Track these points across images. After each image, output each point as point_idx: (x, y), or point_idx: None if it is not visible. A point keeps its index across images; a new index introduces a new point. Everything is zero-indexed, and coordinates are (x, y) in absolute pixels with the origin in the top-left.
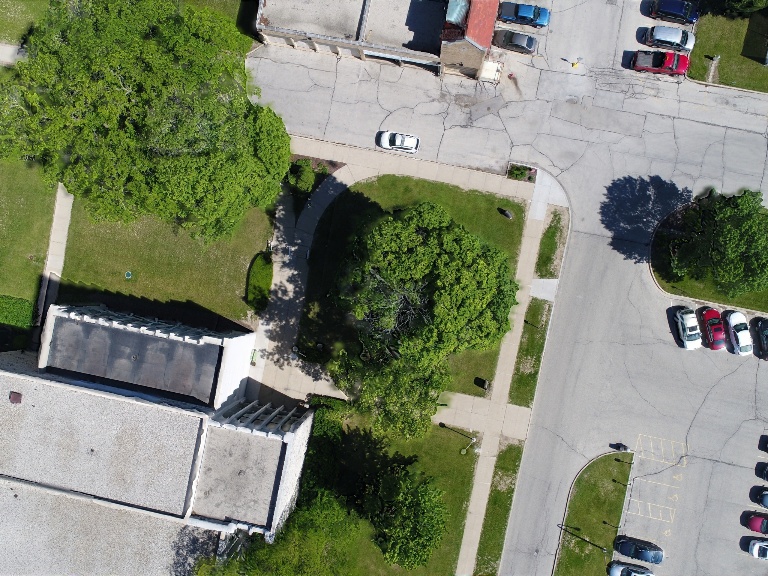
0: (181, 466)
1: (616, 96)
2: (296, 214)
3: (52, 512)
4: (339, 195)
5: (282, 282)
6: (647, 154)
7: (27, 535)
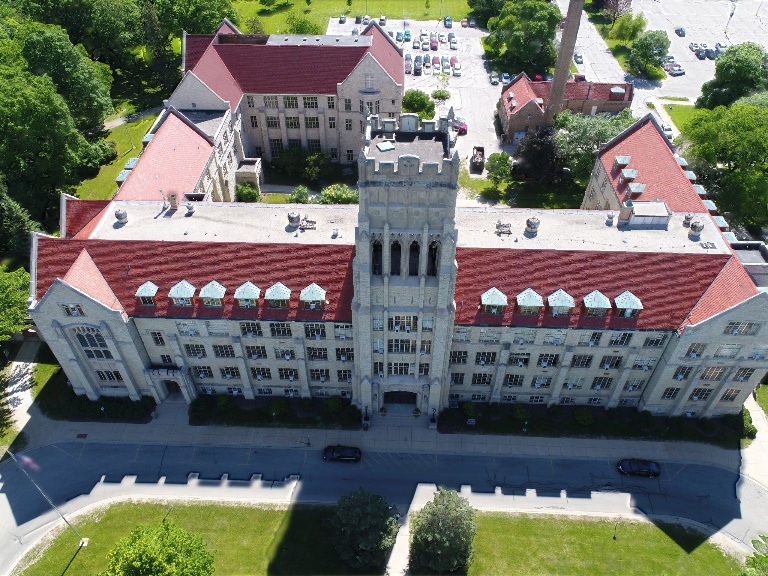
0: None
1: None
2: None
3: None
4: None
5: None
6: None
7: None
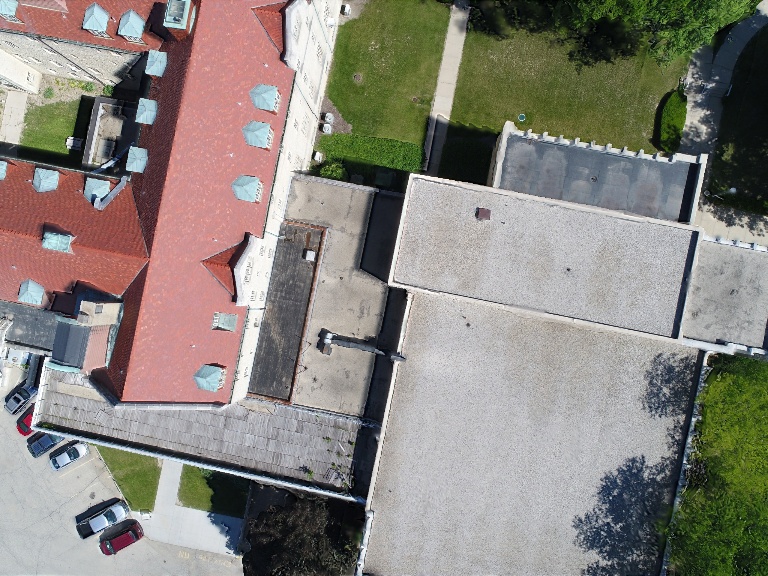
0: (670, 284)
1: None
2: (716, 48)
3: (509, 341)
4: (762, 28)
5: (693, 123)
6: None
7: (481, 366)
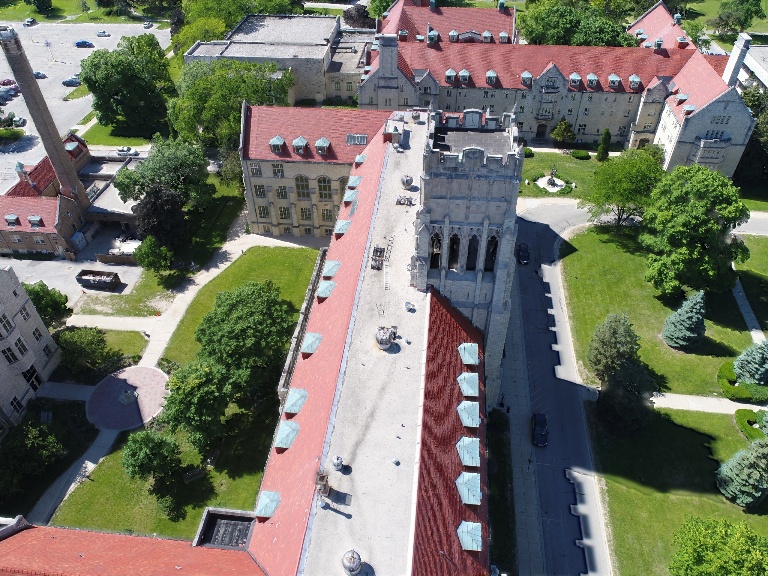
0: None
1: (9, 172)
2: None
3: None
4: None
5: None
6: (6, 158)
7: None
